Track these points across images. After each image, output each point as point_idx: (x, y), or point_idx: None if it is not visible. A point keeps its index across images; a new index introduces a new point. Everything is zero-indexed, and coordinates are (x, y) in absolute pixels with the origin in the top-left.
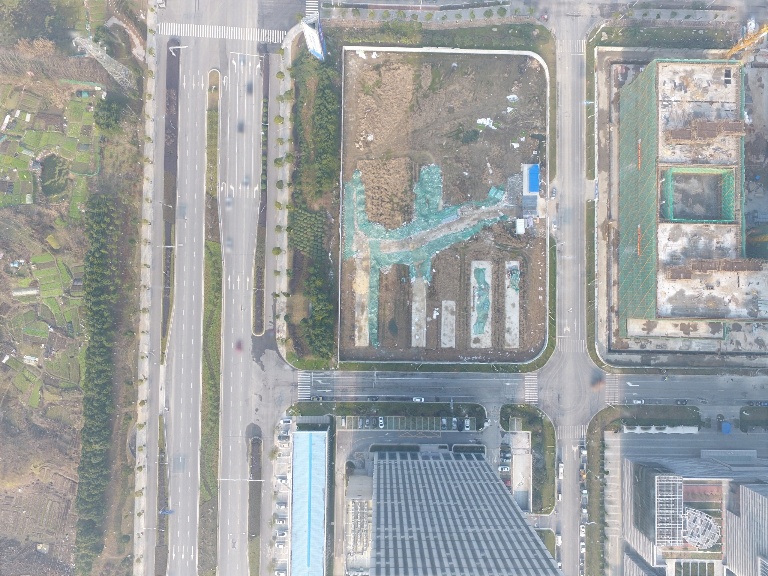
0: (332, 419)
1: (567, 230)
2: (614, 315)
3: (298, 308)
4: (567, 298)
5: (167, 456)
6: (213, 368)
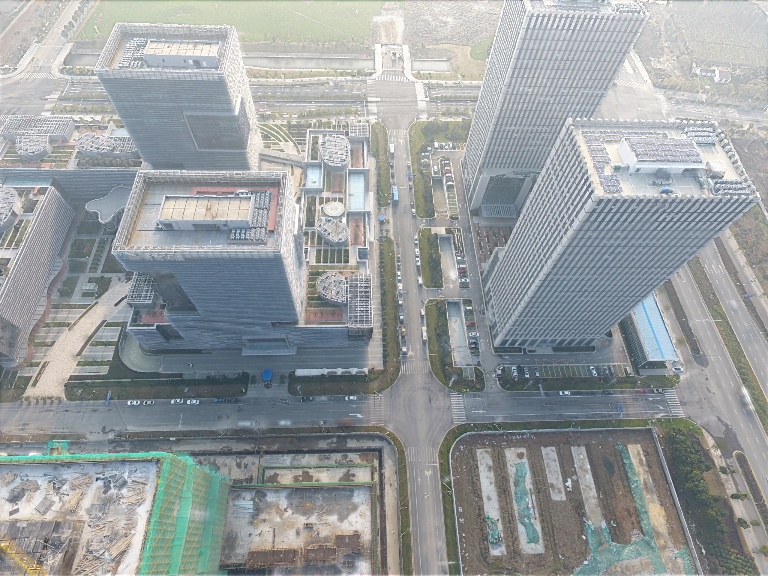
0: (638, 373)
1: None
2: (377, 492)
3: (712, 483)
4: (431, 510)
5: (764, 338)
6: (766, 416)
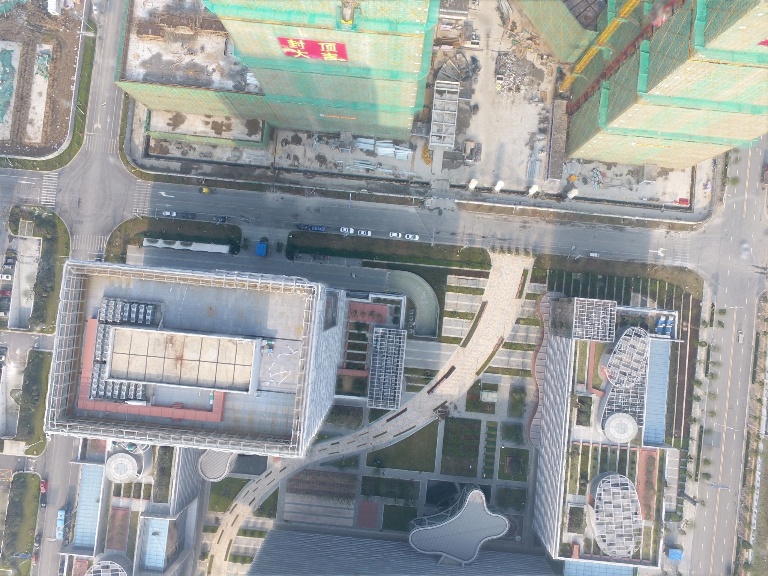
0: None
1: (112, 15)
2: None
3: None
4: (102, 91)
5: None
6: None
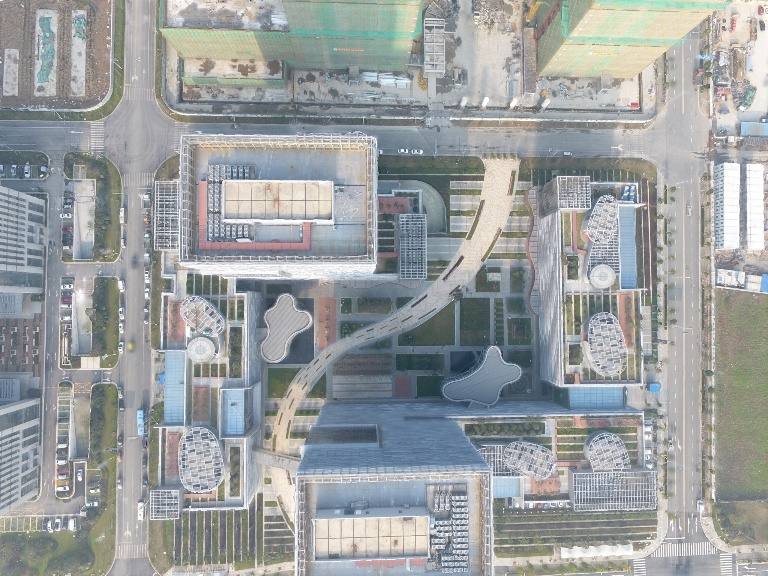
0: None
1: None
2: None
3: None
4: (136, 47)
5: None
6: None
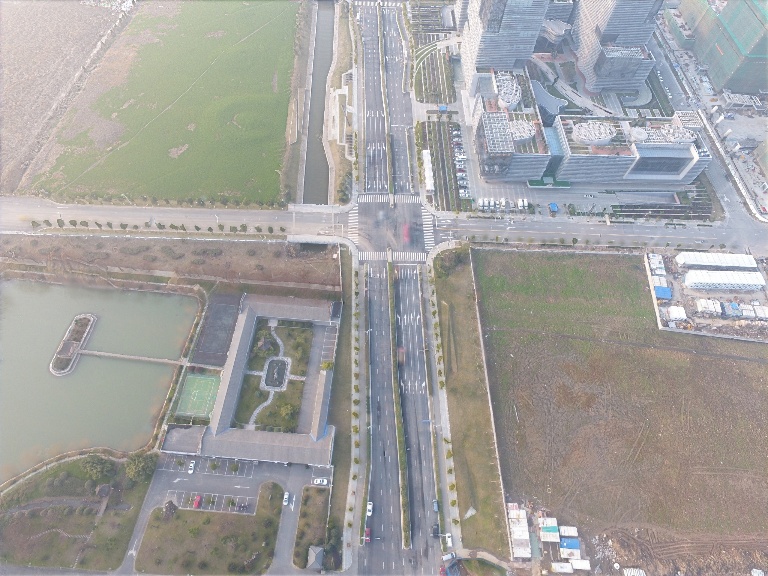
0: None
1: None
2: None
3: None
4: None
5: None
6: None
